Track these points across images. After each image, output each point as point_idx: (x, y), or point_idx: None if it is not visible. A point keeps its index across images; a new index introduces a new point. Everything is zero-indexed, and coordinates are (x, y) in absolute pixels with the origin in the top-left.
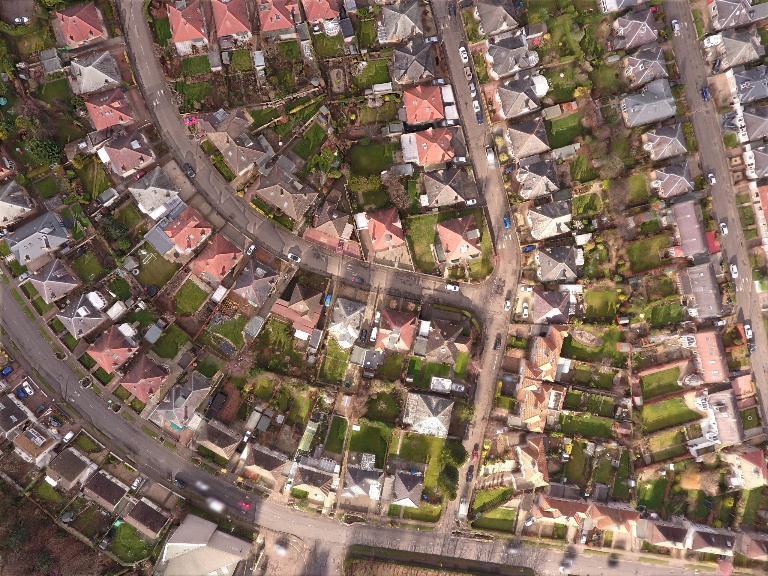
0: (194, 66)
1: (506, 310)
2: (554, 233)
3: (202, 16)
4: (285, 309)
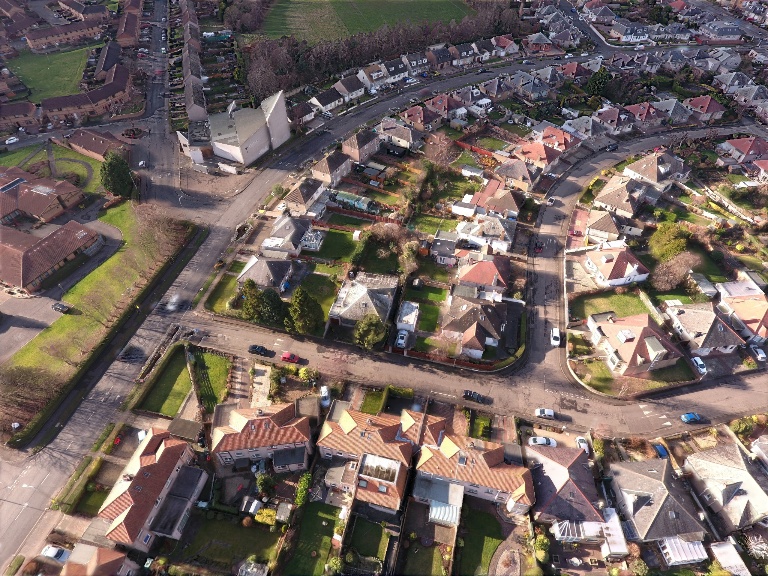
0: (711, 155)
1: (536, 411)
2: (717, 482)
3: (764, 155)
4: (495, 188)
